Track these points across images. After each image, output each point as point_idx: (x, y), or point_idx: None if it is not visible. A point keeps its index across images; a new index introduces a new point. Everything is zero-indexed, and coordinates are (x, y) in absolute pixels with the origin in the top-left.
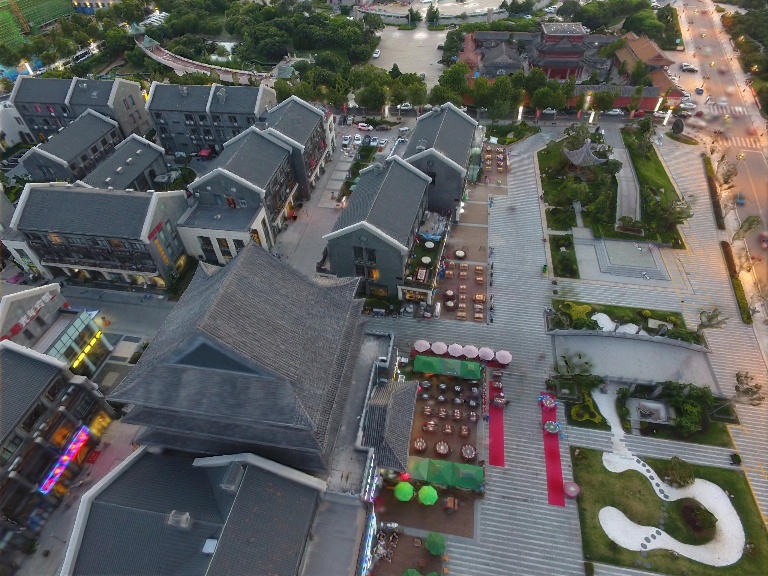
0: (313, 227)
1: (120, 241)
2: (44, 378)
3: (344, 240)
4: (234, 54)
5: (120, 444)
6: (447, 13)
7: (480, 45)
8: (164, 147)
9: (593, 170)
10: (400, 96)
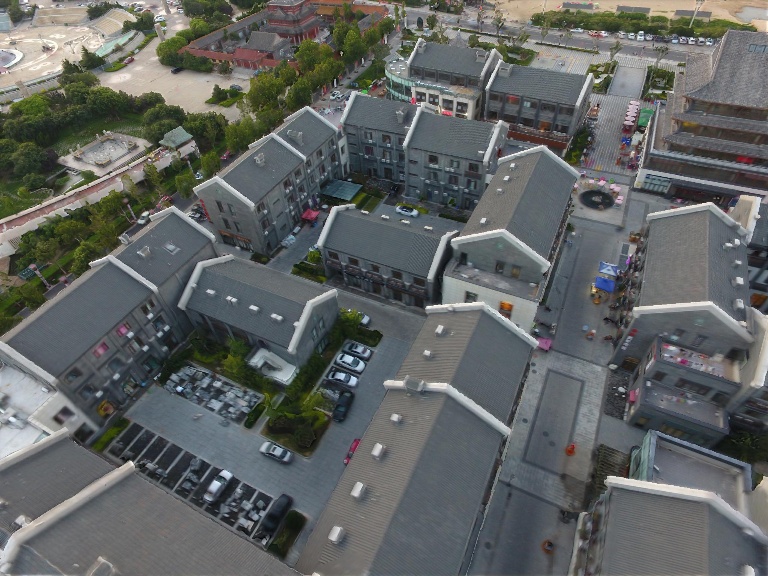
0: None
1: None
2: None
3: None
4: None
5: None
6: (71, 60)
7: None
8: (266, 250)
9: None
10: (314, 83)
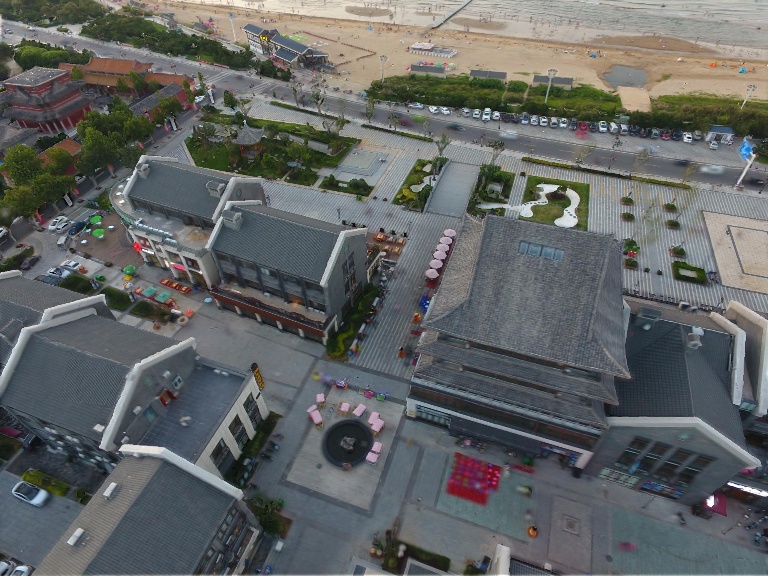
0: (207, 352)
1: None
2: (530, 574)
3: (337, 267)
4: None
5: (528, 557)
6: None
7: None
8: None
9: (252, 146)
10: (3, 218)
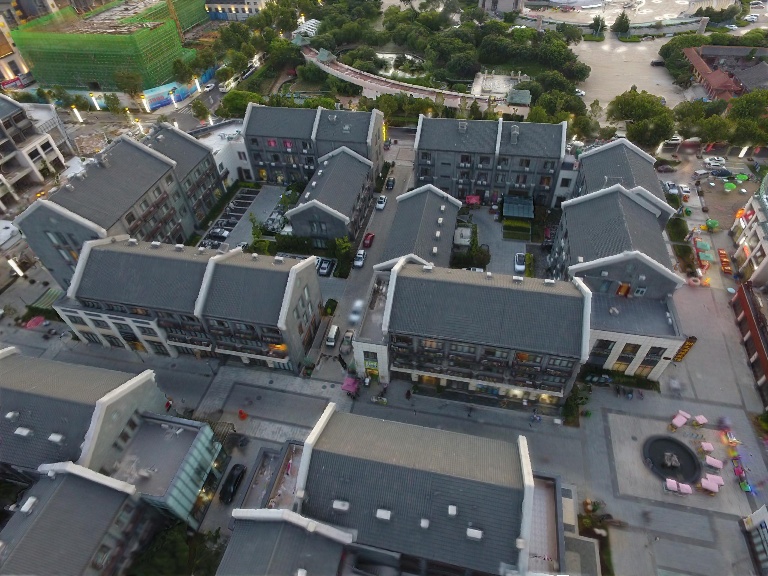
0: (679, 312)
1: (535, 355)
2: None
3: None
4: (398, 67)
5: None
6: None
7: (705, 61)
8: None
9: None
10: (690, 131)
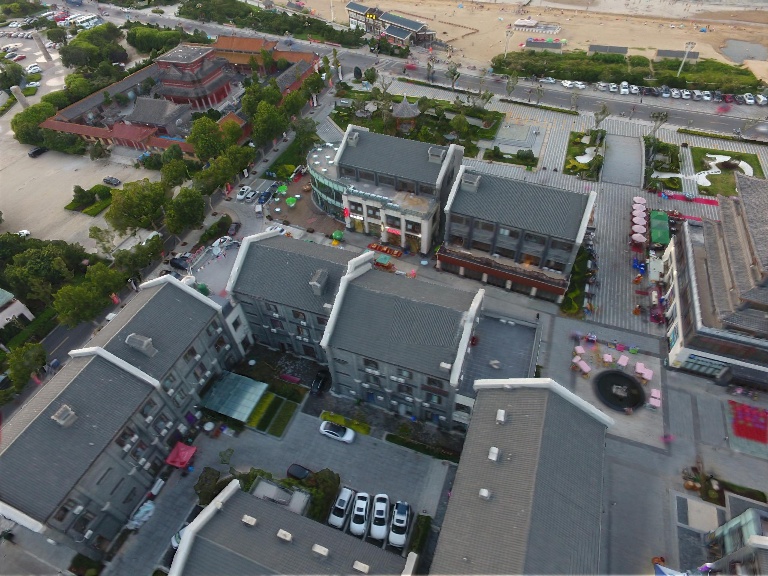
0: None
1: None
2: None
3: None
4: None
5: None
6: None
7: None
8: (94, 554)
9: None
10: (209, 186)
